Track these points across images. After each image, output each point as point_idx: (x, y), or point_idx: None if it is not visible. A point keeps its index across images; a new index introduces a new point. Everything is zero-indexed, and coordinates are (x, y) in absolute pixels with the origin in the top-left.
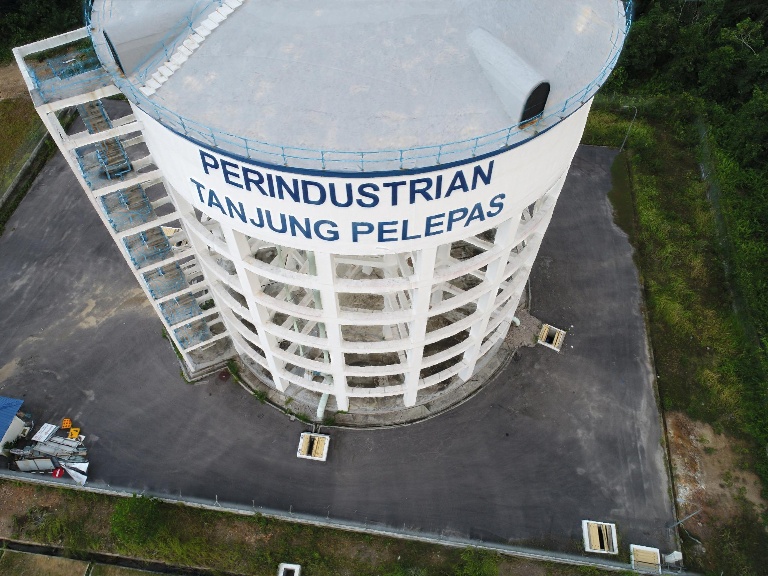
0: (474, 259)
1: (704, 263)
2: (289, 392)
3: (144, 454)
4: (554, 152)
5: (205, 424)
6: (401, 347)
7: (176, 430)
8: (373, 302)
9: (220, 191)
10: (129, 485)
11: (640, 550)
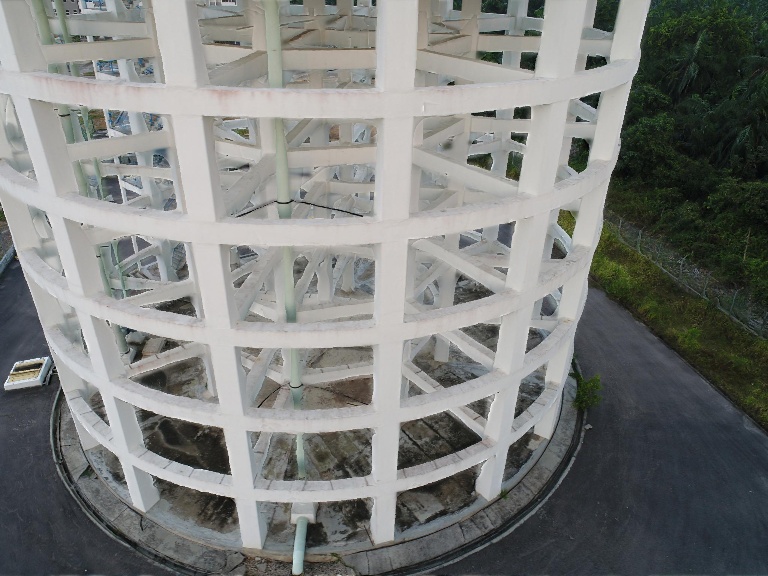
0: None
1: None
2: None
3: None
4: None
5: None
6: None
7: None
8: (272, 362)
9: None
10: (9, 278)
11: None
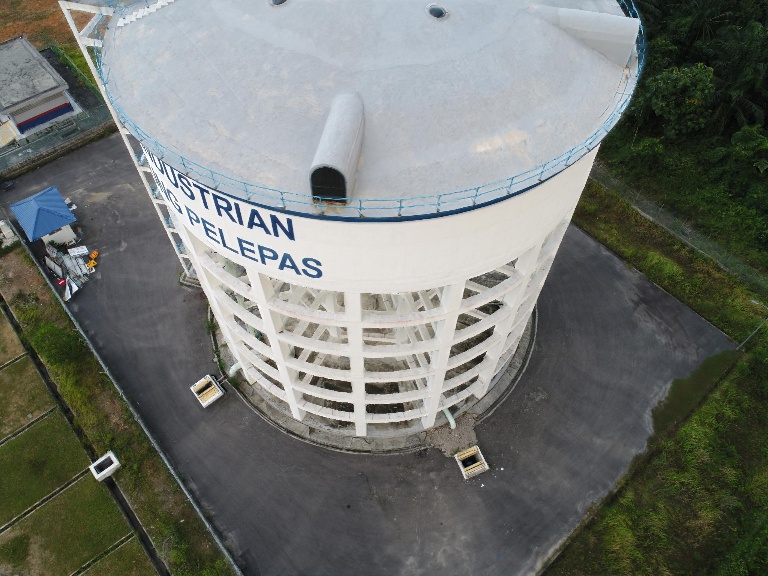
0: (314, 311)
1: (716, 523)
2: None
3: (112, 309)
4: (390, 253)
5: (162, 318)
6: (265, 353)
7: (143, 308)
8: None
9: None
10: (87, 322)
11: None
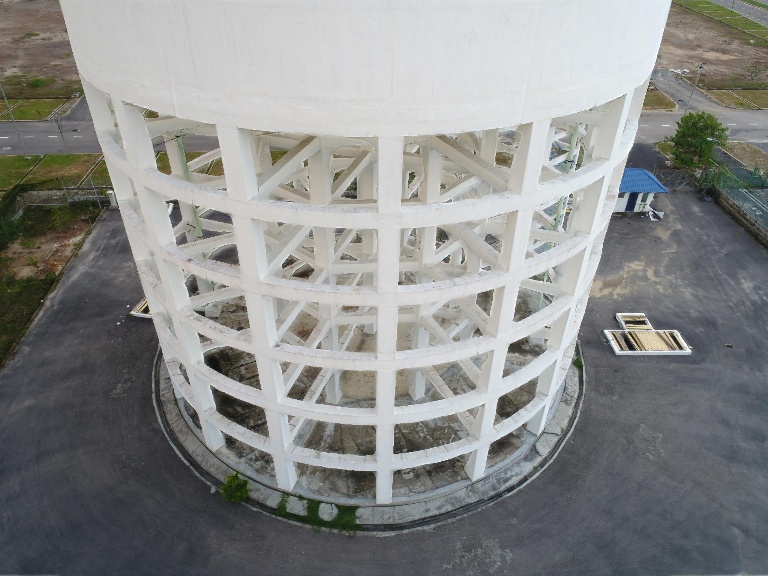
0: None
1: None
2: (413, 237)
3: None
4: None
5: None
6: None
7: None
8: None
9: None
10: None
11: None
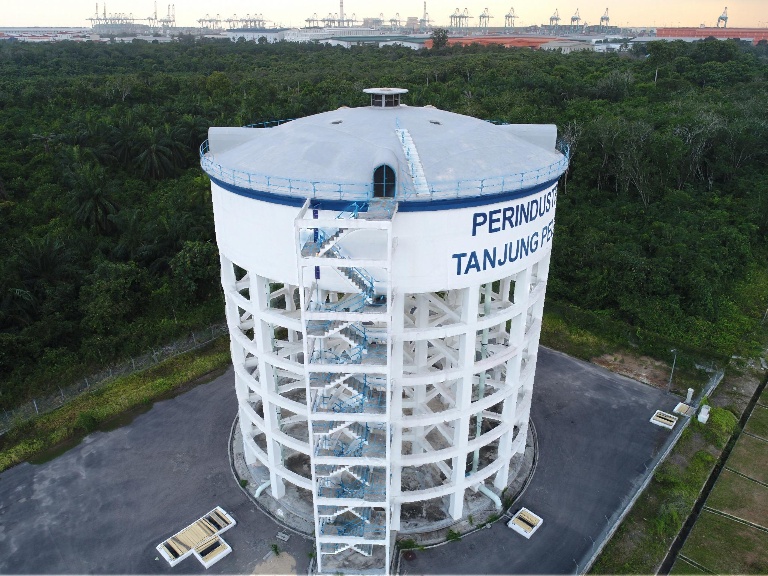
0: None
1: None
2: (465, 512)
3: None
4: None
5: None
6: None
7: None
8: None
9: (481, 247)
10: None
11: (678, 409)
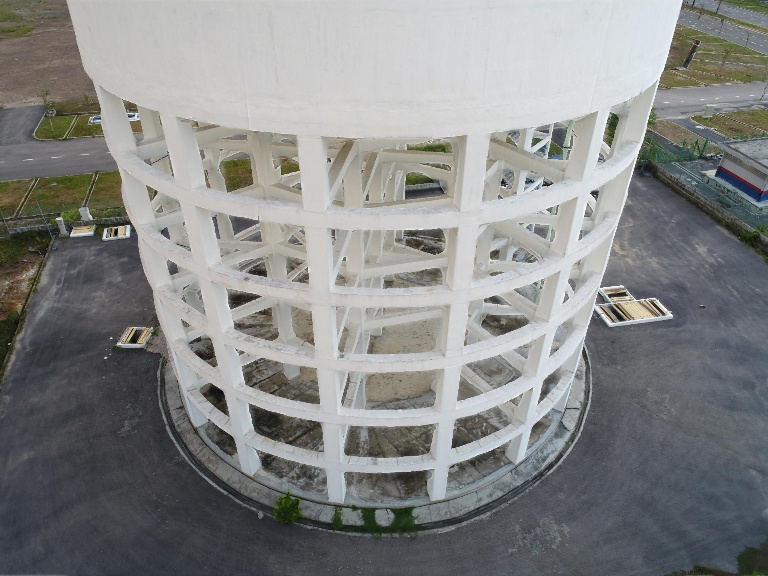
0: None
1: None
2: None
3: None
4: None
5: None
6: None
7: None
8: None
9: None
10: None
11: (86, 232)
